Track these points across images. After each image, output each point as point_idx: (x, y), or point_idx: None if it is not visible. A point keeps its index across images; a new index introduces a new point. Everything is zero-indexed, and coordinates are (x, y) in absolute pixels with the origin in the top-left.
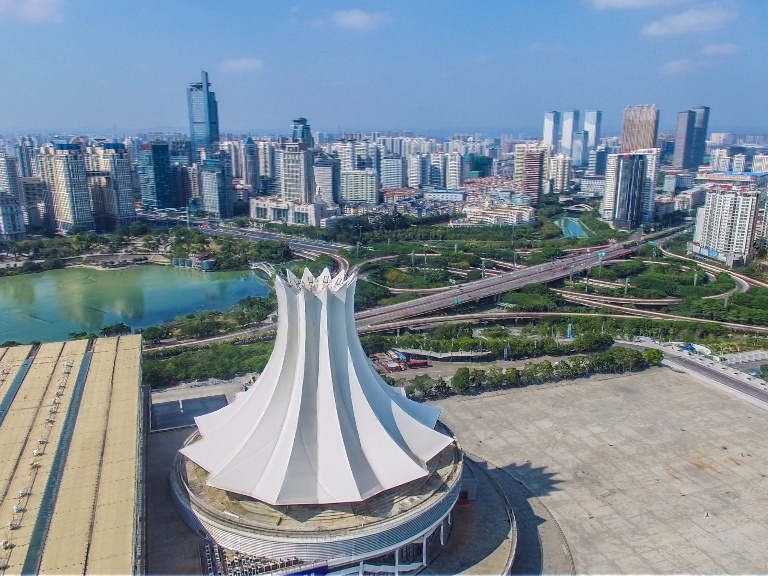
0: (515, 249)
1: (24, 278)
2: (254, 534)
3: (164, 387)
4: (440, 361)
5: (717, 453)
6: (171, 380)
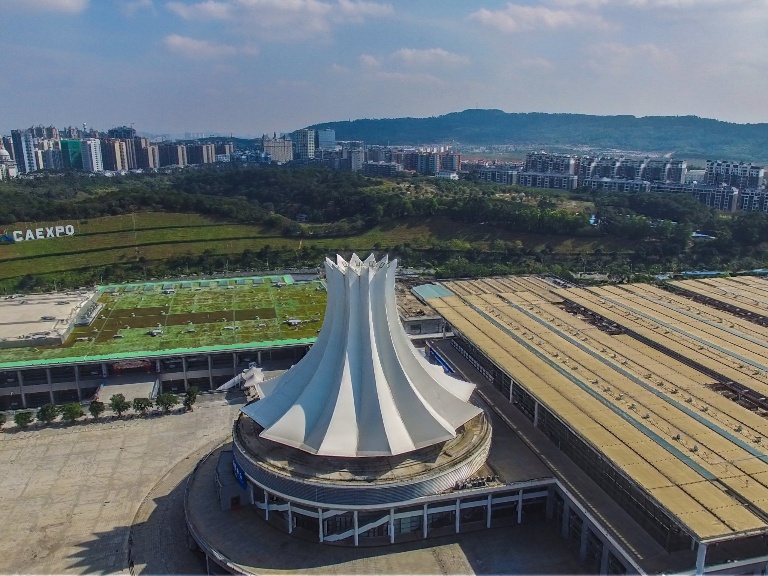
0: None
1: None
2: None
3: None
4: None
5: None
6: None
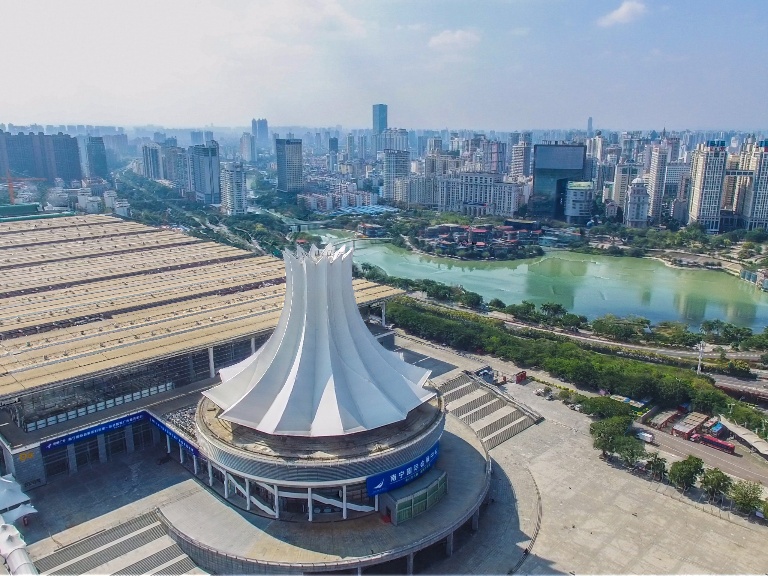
0: None
1: (605, 259)
2: None
3: (473, 352)
4: (765, 458)
5: None
6: (479, 349)
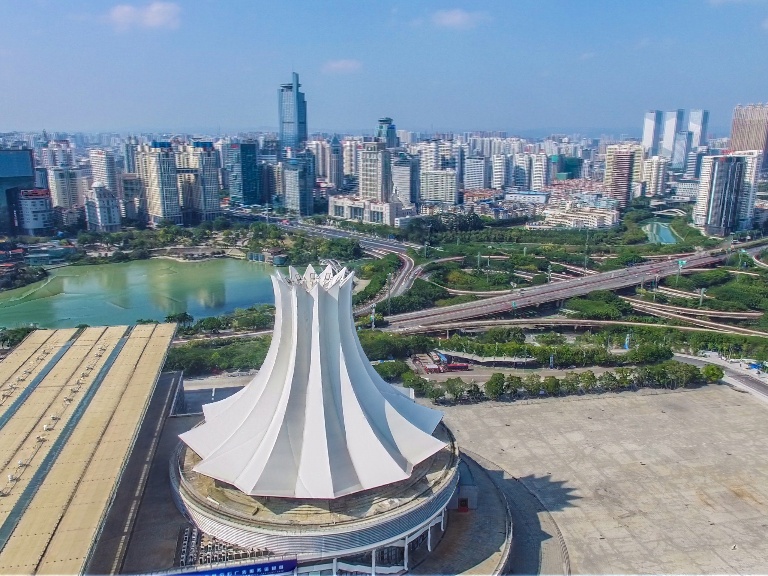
0: (591, 254)
1: (113, 267)
2: (229, 521)
3: (207, 375)
4: (482, 365)
5: (762, 482)
6: (214, 369)
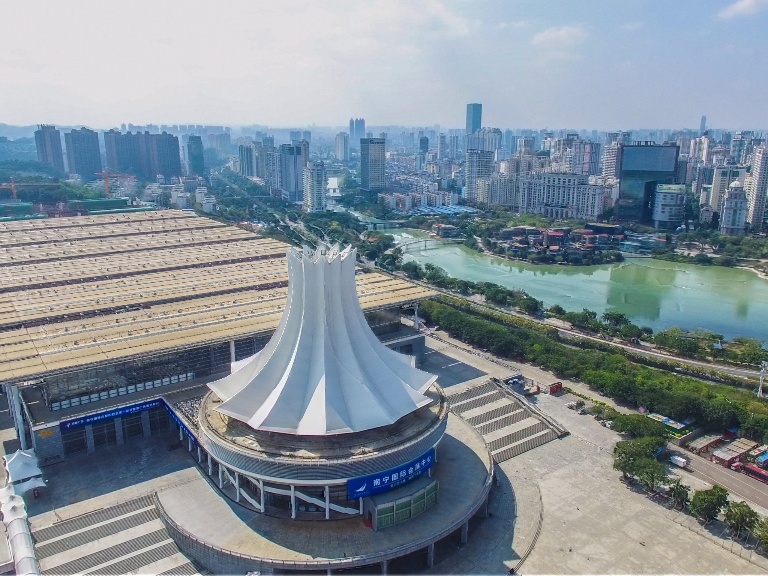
0: None
1: (691, 267)
2: None
3: (513, 359)
4: None
5: None
6: (520, 356)
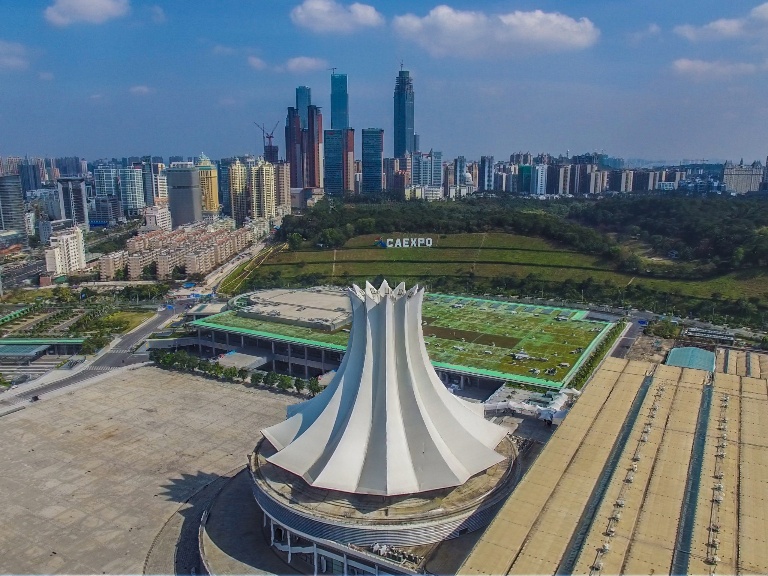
0: None
1: None
2: None
3: None
4: None
5: (79, 434)
6: None
